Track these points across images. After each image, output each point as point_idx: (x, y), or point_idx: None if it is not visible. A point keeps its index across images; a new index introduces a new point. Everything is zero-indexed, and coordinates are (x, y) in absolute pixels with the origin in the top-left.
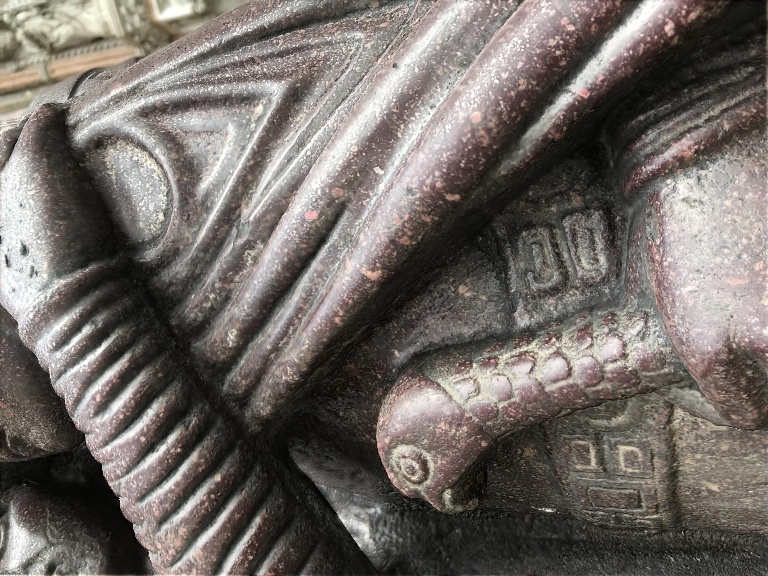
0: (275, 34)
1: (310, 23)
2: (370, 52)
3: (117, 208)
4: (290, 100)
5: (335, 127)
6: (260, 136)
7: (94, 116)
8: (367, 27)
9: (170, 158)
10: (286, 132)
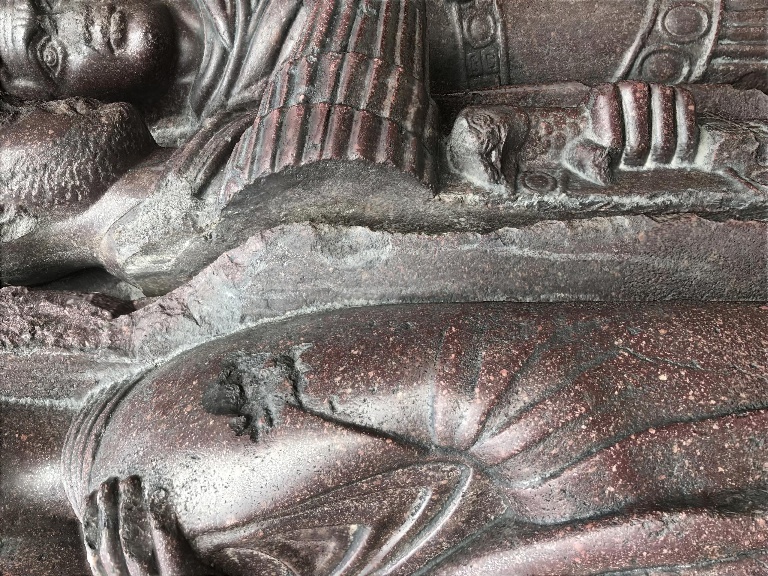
0: (359, 480)
1: (385, 471)
2: (437, 502)
3: (243, 575)
4: (381, 529)
5: (421, 557)
6: (363, 552)
7: (213, 534)
8: (431, 481)
9: (292, 562)
10: (379, 545)
